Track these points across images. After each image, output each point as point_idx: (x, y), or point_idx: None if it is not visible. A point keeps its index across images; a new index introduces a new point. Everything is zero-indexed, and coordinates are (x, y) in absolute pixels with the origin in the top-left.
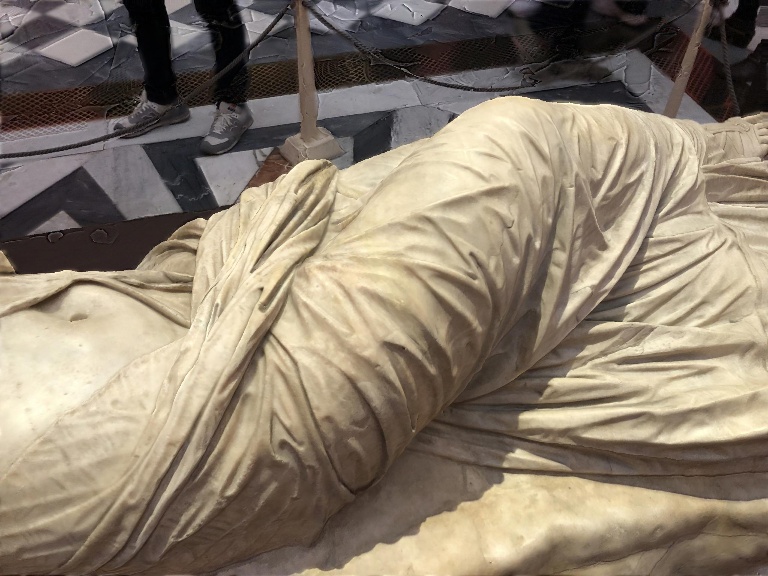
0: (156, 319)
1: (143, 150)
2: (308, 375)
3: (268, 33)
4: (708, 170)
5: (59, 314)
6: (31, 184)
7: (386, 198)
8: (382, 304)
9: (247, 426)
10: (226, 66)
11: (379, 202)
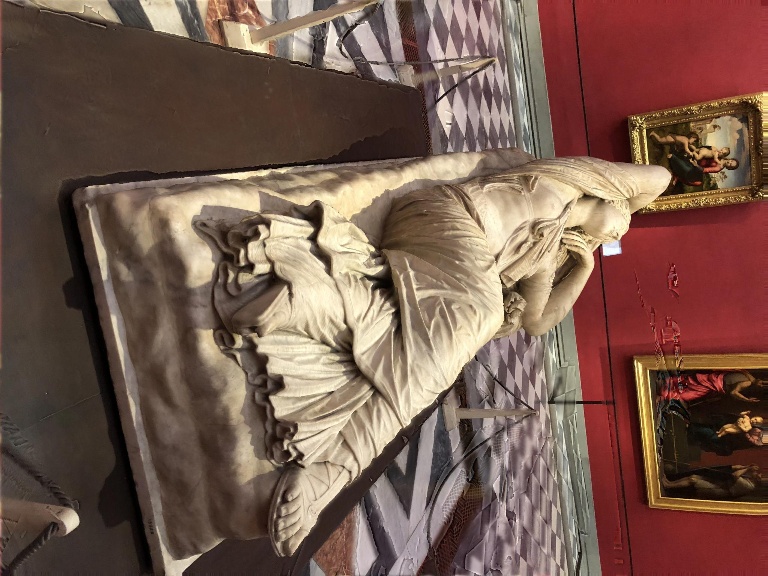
0: None
1: None
2: None
3: None
4: (363, 398)
5: None
6: None
7: None
8: None
9: None
10: None
11: None
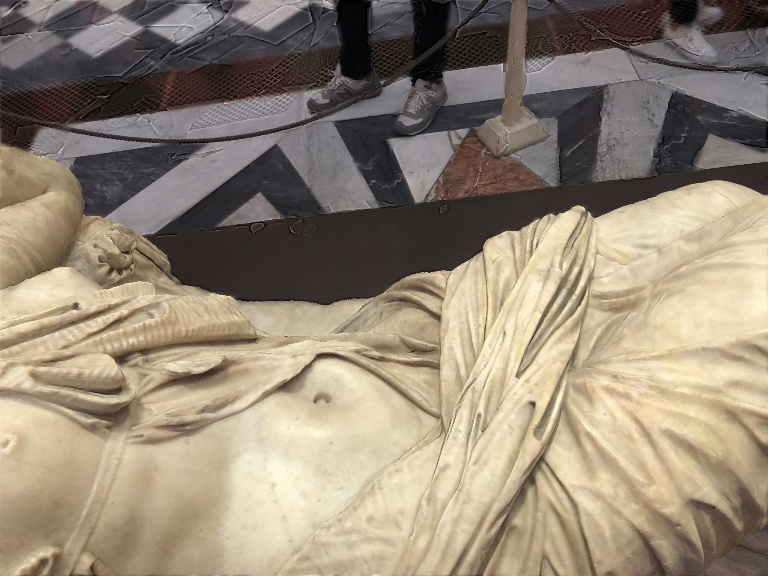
0: (401, 405)
1: (335, 128)
2: (591, 523)
3: (480, 10)
4: None
5: (304, 393)
6: (230, 162)
7: (695, 306)
8: (692, 454)
9: (511, 562)
10: (431, 46)
11: (684, 310)
